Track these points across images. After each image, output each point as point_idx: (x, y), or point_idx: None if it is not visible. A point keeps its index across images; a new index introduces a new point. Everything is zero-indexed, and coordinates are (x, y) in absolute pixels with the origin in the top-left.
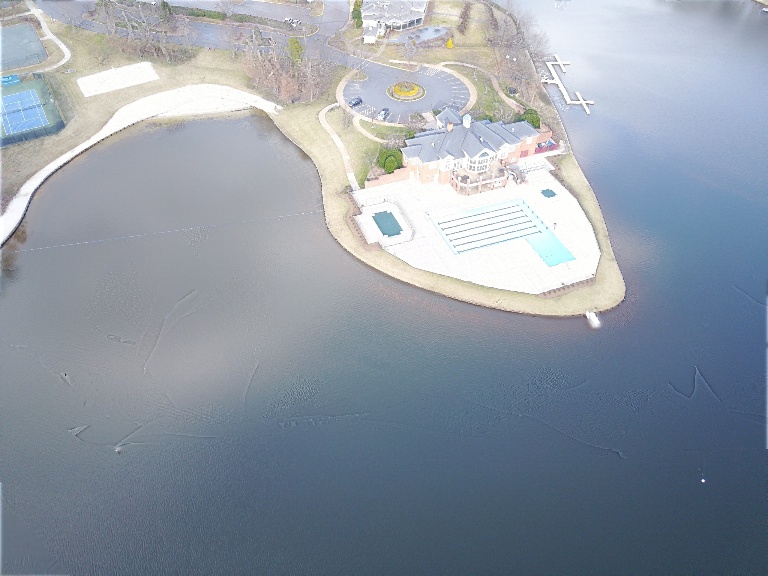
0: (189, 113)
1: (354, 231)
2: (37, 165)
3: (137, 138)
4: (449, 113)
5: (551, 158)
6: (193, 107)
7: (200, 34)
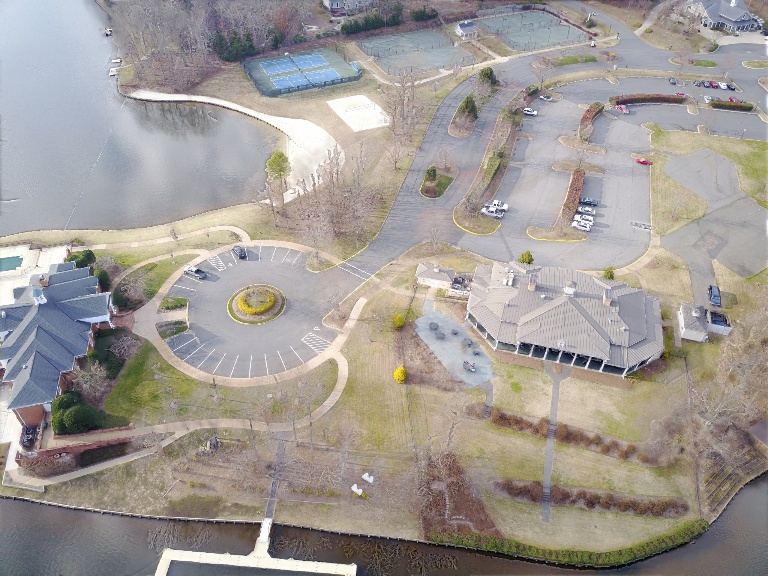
0: (290, 155)
1: (8, 243)
2: (226, 97)
3: (256, 134)
4: (93, 296)
5: (1, 449)
6: (300, 156)
7: (453, 144)
